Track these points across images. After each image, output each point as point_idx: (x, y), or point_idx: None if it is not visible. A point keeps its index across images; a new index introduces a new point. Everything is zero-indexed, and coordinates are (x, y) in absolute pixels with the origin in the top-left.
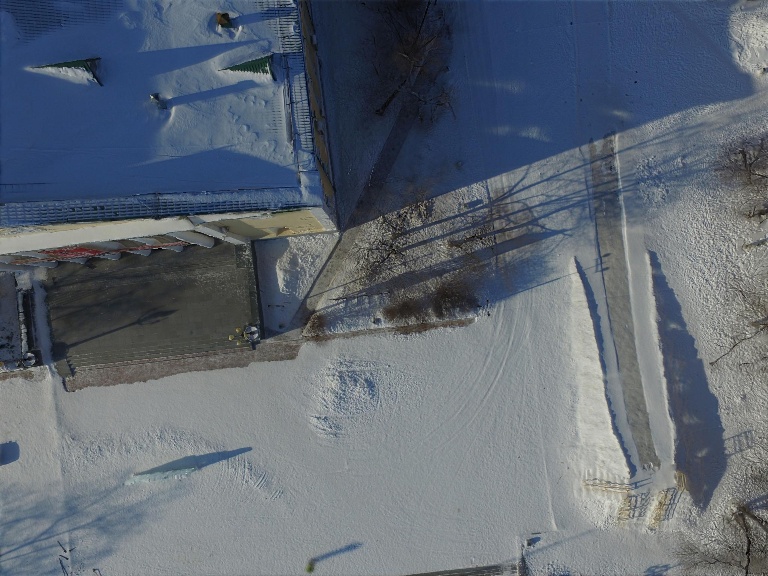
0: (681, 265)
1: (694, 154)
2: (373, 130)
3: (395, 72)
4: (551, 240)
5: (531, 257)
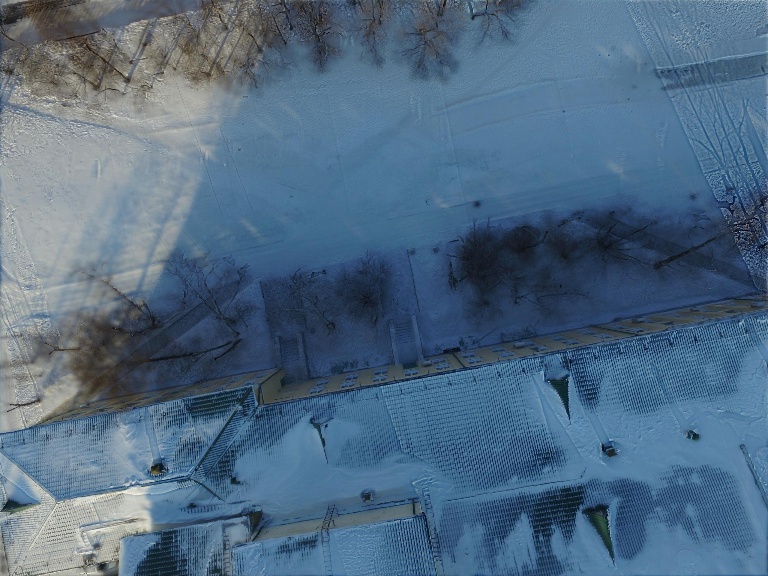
0: (766, 8)
1: (667, 3)
2: (670, 271)
3: (620, 256)
4: (752, 116)
5: (767, 132)
